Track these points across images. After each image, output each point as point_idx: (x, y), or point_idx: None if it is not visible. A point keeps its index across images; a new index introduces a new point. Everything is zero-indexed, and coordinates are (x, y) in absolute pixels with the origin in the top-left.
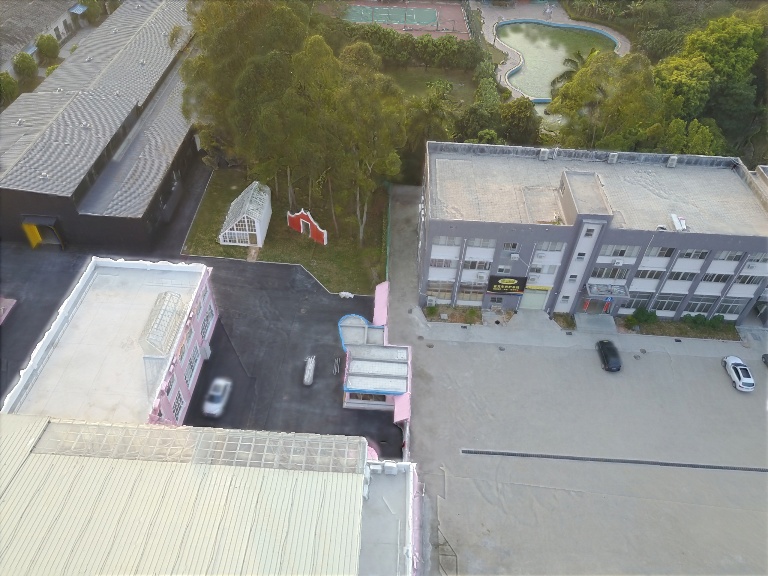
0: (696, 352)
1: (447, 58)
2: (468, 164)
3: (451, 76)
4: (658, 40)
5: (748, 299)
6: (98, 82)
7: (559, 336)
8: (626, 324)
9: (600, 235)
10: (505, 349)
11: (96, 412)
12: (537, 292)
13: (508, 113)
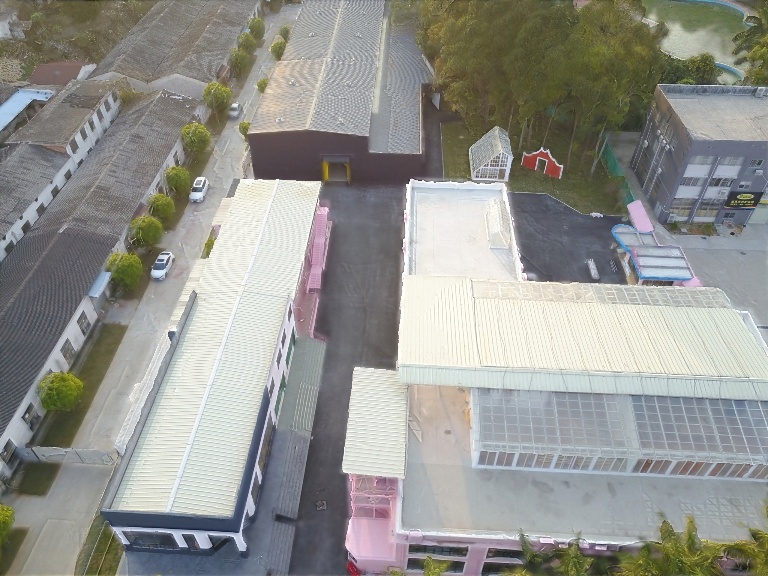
0: None
1: None
2: (696, 102)
3: None
4: None
5: None
6: (333, 52)
7: None
8: None
9: None
10: (746, 253)
11: None
12: (767, 207)
13: (693, 67)
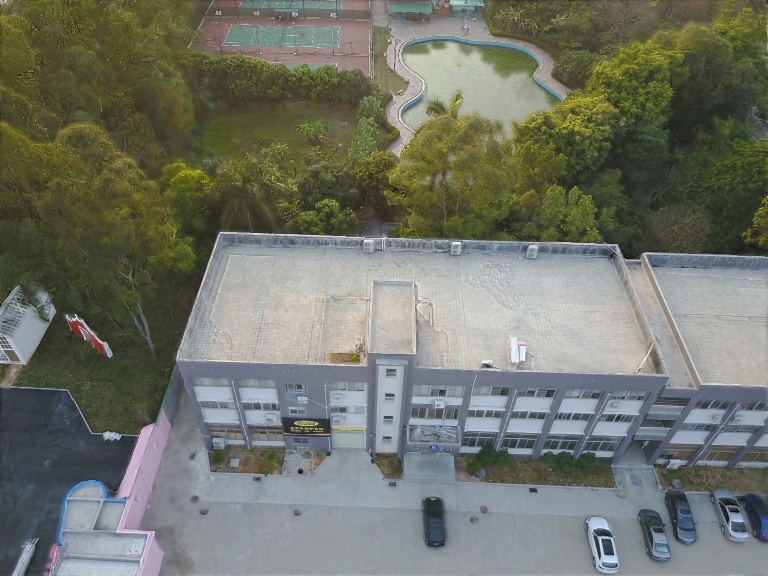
0: (553, 508)
1: (326, 93)
2: (269, 262)
3: (335, 112)
4: (578, 63)
5: (621, 437)
6: None
7: (378, 489)
8: (468, 468)
9: (404, 376)
10: (302, 513)
11: None
12: (350, 431)
13: (365, 172)
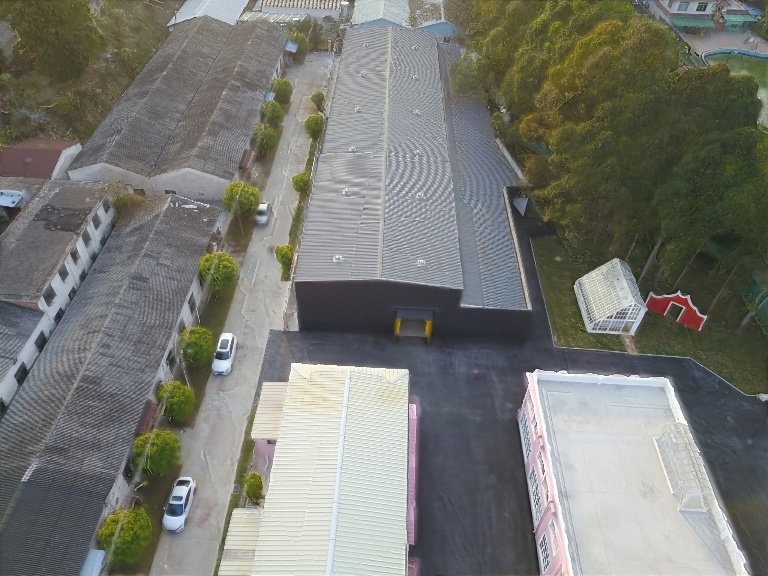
0: None
1: None
2: None
3: None
4: None
5: None
6: (389, 139)
7: None
8: None
9: None
10: None
11: None
12: None
13: None
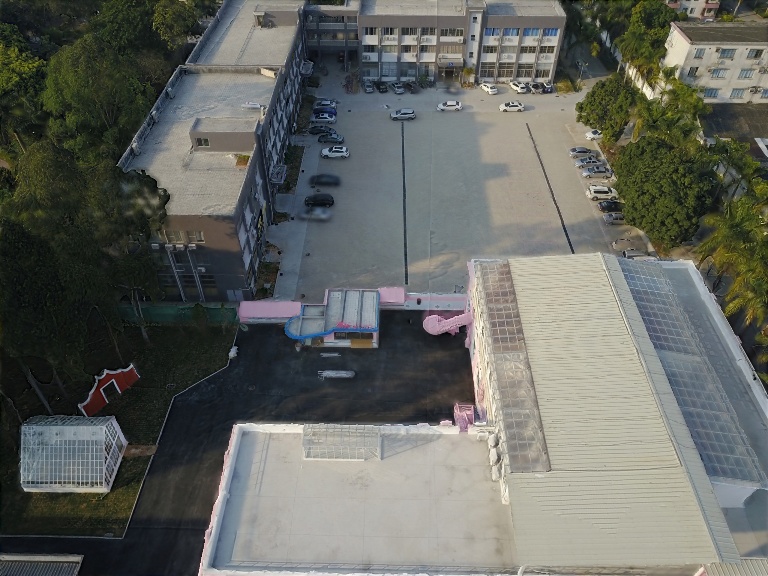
0: (314, 166)
1: None
2: None
3: None
4: None
5: (286, 124)
6: None
7: (295, 223)
8: (287, 188)
9: (263, 138)
10: (308, 253)
11: (458, 483)
12: None
13: None
